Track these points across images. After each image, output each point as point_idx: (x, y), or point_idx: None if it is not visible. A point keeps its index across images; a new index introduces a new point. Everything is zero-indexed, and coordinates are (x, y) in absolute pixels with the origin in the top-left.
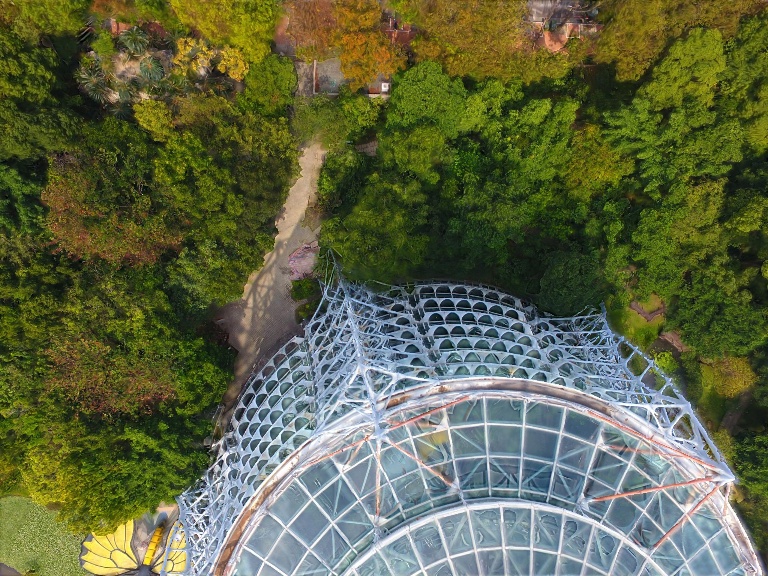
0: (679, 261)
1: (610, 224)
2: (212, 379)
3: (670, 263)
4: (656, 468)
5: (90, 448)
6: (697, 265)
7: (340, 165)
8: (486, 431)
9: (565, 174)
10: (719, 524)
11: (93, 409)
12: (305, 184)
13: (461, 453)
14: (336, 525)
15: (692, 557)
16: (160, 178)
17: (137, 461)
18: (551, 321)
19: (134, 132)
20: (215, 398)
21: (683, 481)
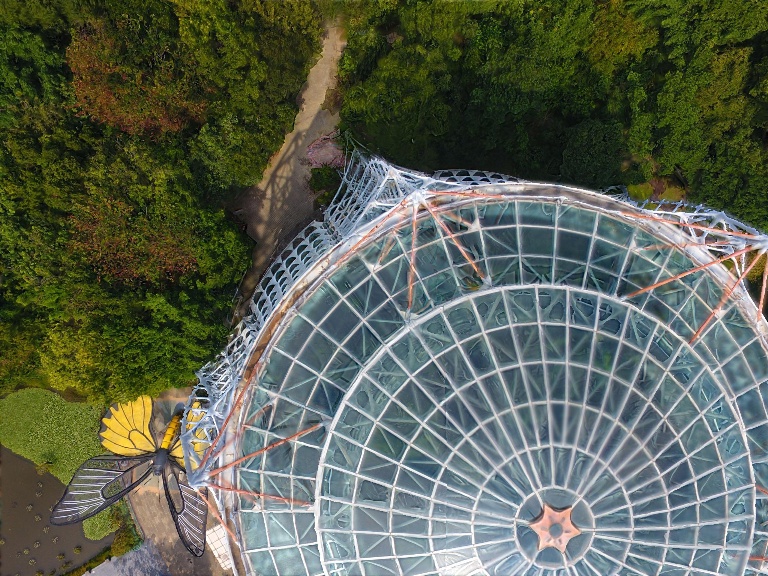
0: (703, 135)
1: (634, 89)
2: (233, 251)
3: (694, 133)
4: (689, 275)
5: (111, 315)
6: (721, 138)
7: (361, 46)
8: (518, 232)
9: (588, 49)
10: (753, 333)
11: (115, 274)
12: (324, 75)
13: (493, 254)
14: (367, 322)
15: (726, 362)
16: (184, 37)
17: (158, 330)
18: None
19: (156, 3)
20: (235, 275)
21: (716, 289)
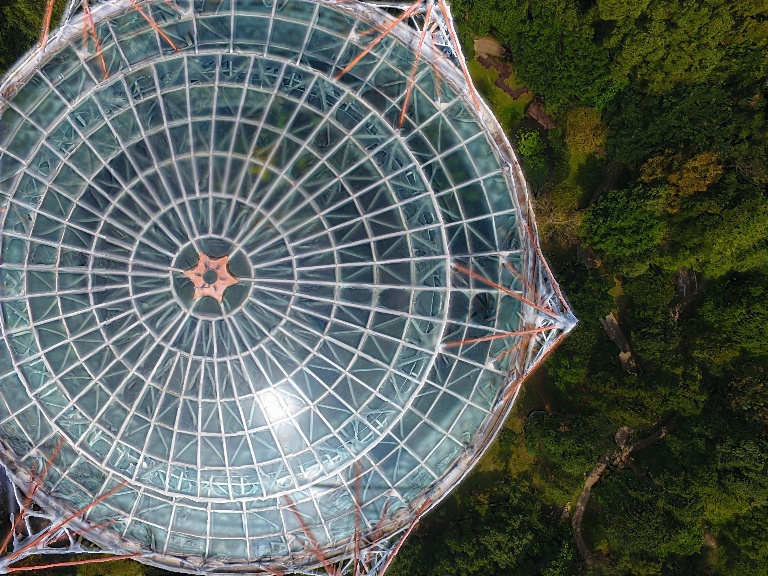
0: None
1: None
2: None
3: None
4: (412, 68)
5: None
6: (538, 0)
7: None
8: (232, 21)
9: None
10: (478, 127)
11: None
12: None
13: None
14: None
15: (446, 153)
16: None
17: None
18: None
19: None
20: None
21: (441, 83)
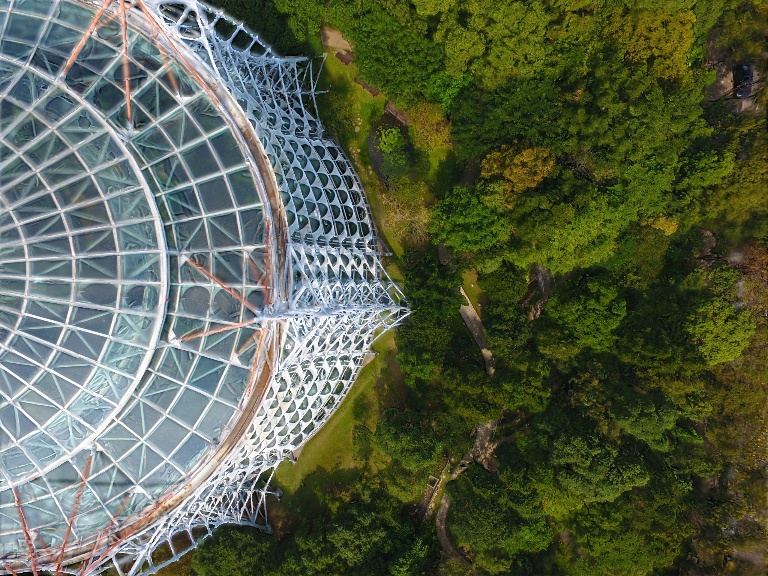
0: None
1: None
2: None
3: None
4: (155, 62)
5: None
6: None
7: None
8: None
9: None
10: (223, 122)
11: None
12: None
13: None
14: None
15: (185, 148)
16: None
17: None
18: (239, 67)
19: None
20: None
21: (186, 77)
